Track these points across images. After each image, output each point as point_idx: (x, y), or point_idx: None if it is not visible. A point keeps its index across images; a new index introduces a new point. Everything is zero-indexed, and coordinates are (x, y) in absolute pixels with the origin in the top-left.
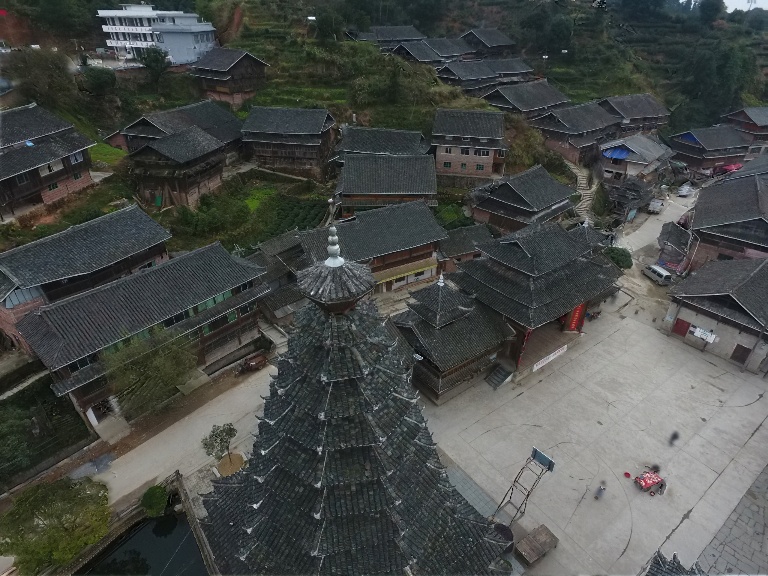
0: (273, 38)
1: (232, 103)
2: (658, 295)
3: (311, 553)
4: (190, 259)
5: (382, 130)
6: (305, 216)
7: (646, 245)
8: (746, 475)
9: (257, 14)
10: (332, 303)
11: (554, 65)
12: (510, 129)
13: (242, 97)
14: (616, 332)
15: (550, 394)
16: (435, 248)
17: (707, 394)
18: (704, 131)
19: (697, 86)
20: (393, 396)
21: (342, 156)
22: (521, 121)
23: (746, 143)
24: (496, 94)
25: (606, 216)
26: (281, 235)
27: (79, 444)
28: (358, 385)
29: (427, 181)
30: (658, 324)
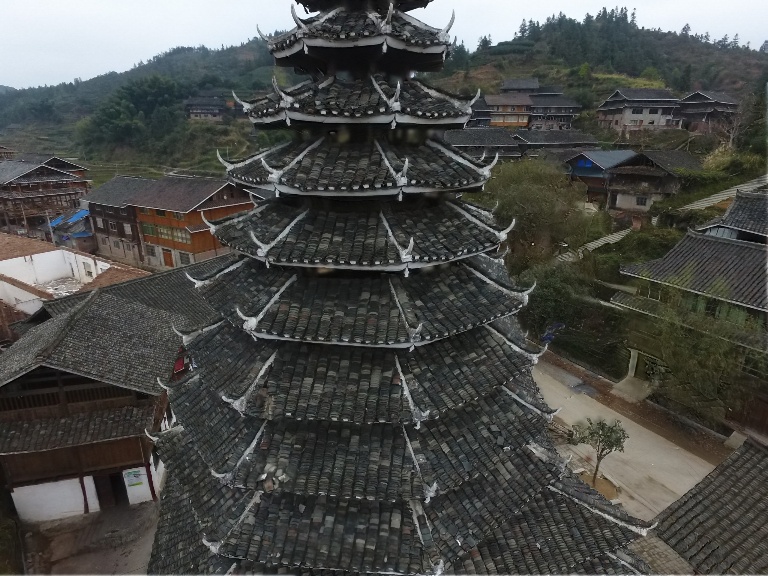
0: None
1: None
2: None
3: None
4: None
5: None
6: None
7: None
8: None
9: None
10: None
11: None
12: None
13: None
14: None
15: None
16: None
17: None
18: None
19: None
20: None
21: None
22: None
23: None
24: None
25: None
26: None
27: (611, 379)
28: None
29: None
30: None
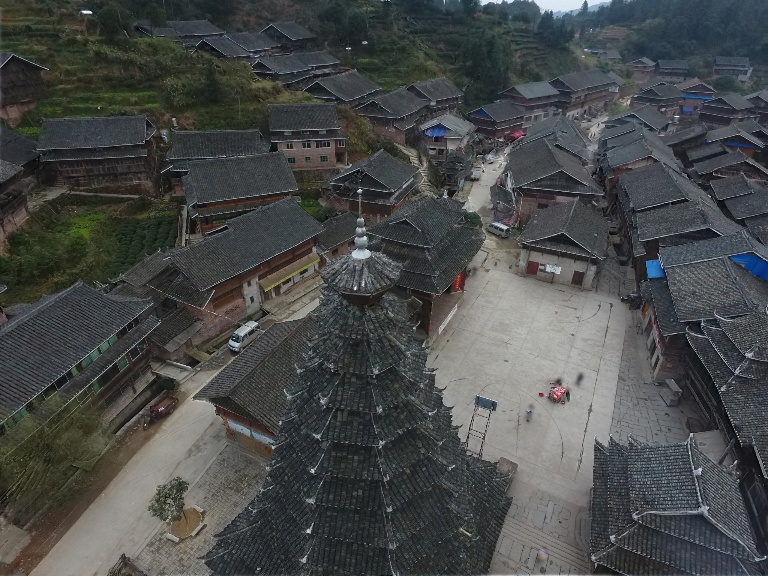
0: (40, 36)
1: (6, 118)
2: (505, 246)
3: (390, 547)
4: (51, 309)
5: (215, 132)
6: (154, 236)
7: (480, 207)
8: (613, 366)
9: (7, 7)
10: (376, 294)
11: (358, 56)
12: (340, 119)
13: (19, 110)
14: (487, 284)
15: (460, 349)
16: (314, 243)
17: (567, 315)
18: (491, 106)
19: (476, 69)
20: None
21: (176, 165)
22: (348, 110)
23: (521, 114)
24: (317, 86)
25: (440, 188)
26: (144, 261)
27: None
28: (397, 370)
29: (285, 178)
30: (514, 270)
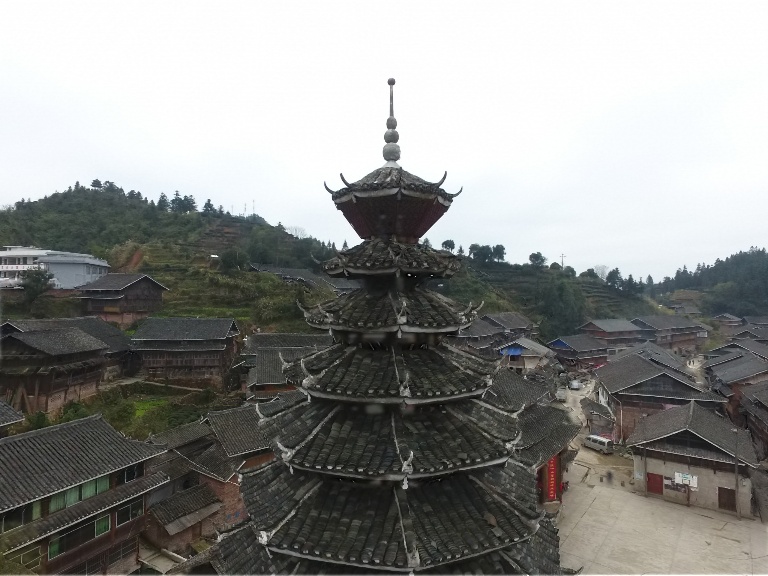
0: (173, 271)
1: (120, 322)
2: None
3: None
4: (52, 434)
5: (292, 335)
6: None
7: None
8: None
9: (158, 254)
10: (407, 196)
11: None
12: None
13: (133, 317)
14: (594, 501)
15: None
16: None
17: (727, 548)
18: (569, 338)
19: (549, 308)
20: (484, 408)
21: (249, 361)
22: None
23: (603, 346)
24: None
25: None
26: (181, 426)
27: None
28: (444, 358)
29: None
30: (629, 488)
